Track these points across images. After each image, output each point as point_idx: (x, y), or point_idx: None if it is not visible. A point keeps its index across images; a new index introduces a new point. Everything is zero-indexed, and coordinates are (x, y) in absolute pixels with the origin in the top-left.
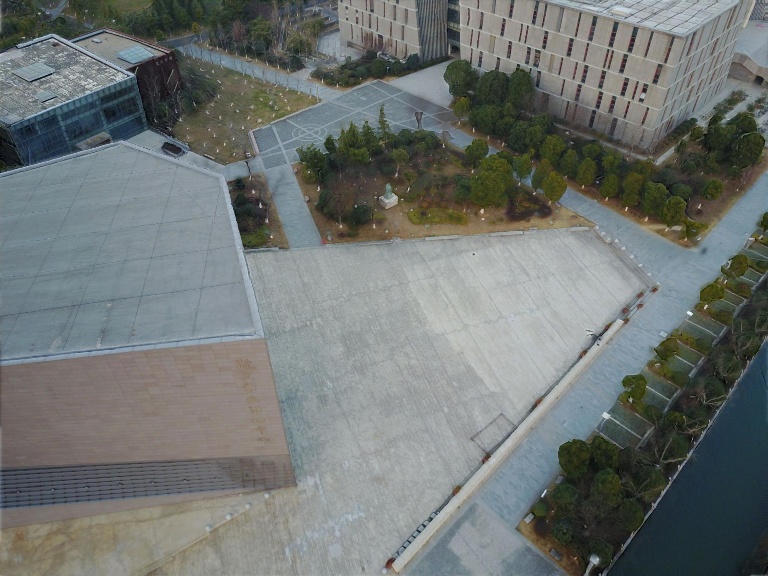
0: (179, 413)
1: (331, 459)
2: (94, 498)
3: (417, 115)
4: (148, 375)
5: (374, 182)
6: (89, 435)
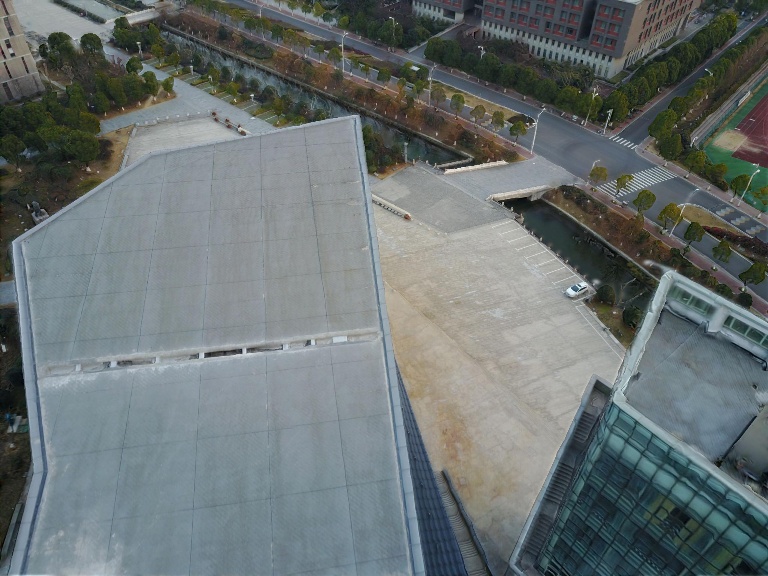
0: None
1: None
2: None
3: None
4: None
5: None
6: None
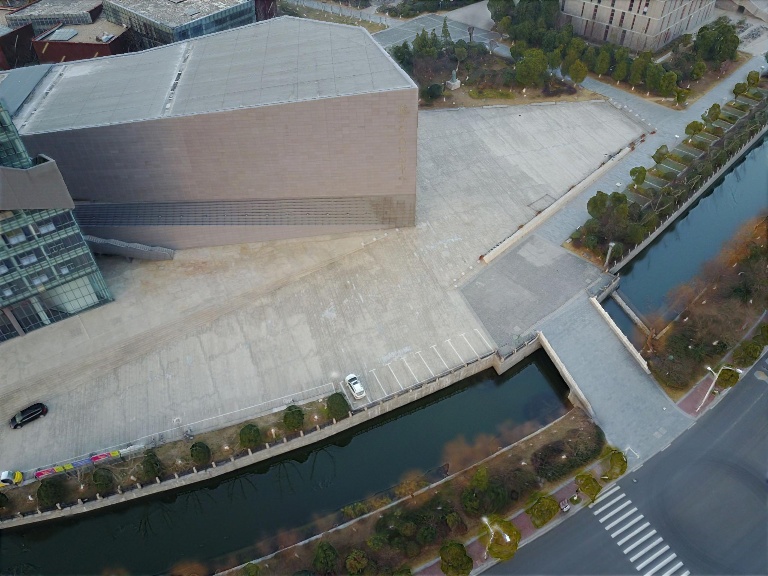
0: (356, 152)
1: (435, 215)
2: (291, 223)
3: (469, 30)
4: (345, 117)
5: (440, 75)
6: (297, 170)
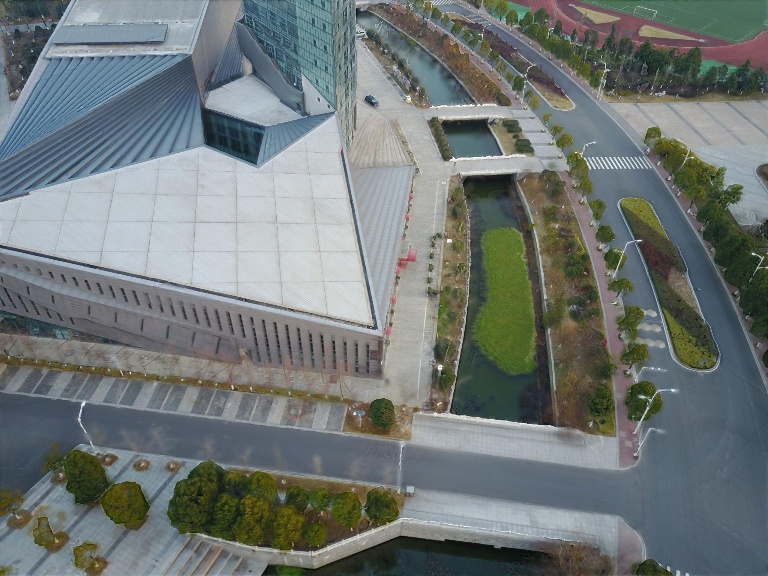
0: None
1: None
2: None
3: None
4: None
5: (49, 5)
6: None
